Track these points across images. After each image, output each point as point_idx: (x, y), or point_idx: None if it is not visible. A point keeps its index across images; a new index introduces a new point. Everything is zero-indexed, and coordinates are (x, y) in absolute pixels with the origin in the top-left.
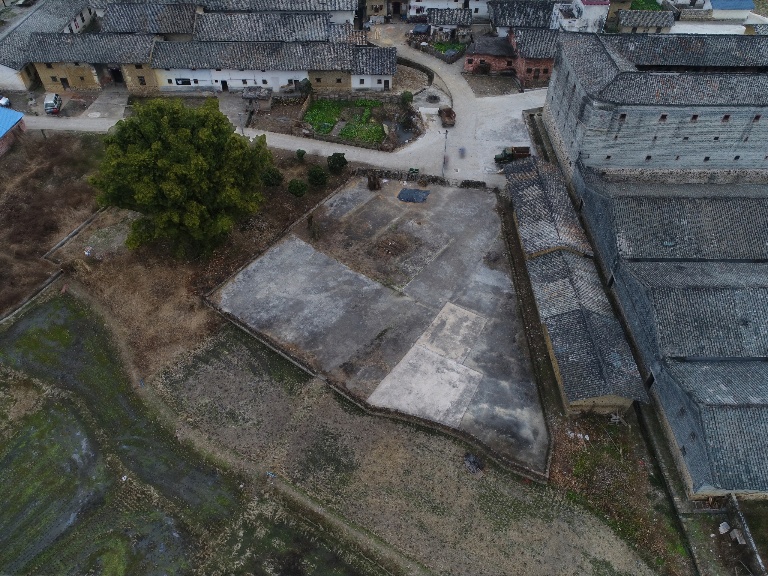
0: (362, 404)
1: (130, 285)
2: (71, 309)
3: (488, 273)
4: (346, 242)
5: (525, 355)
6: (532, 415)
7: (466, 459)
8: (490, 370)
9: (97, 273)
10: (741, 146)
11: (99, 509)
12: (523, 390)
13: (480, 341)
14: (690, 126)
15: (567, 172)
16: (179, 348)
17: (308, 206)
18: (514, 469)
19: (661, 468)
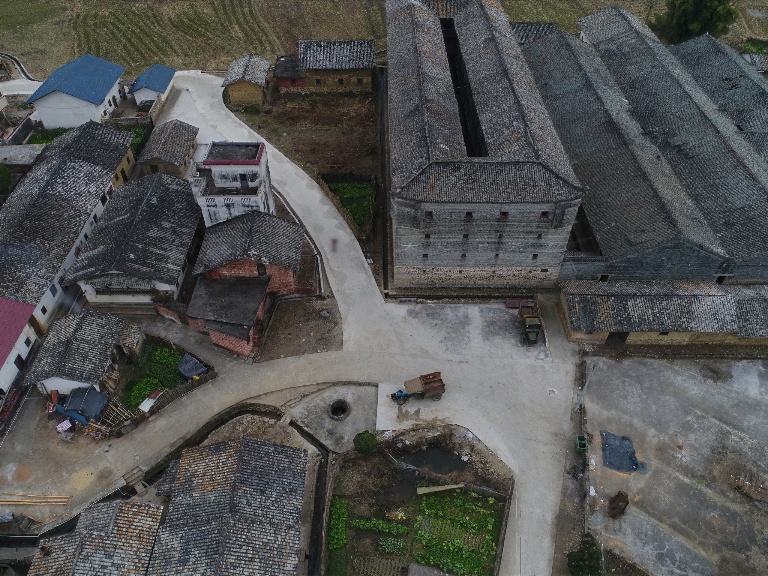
0: None
1: None
2: None
3: (741, 381)
4: (766, 548)
5: None
6: None
7: None
8: None
9: None
10: None
11: None
12: None
13: None
14: None
15: (540, 280)
16: None
17: None
18: None
19: None
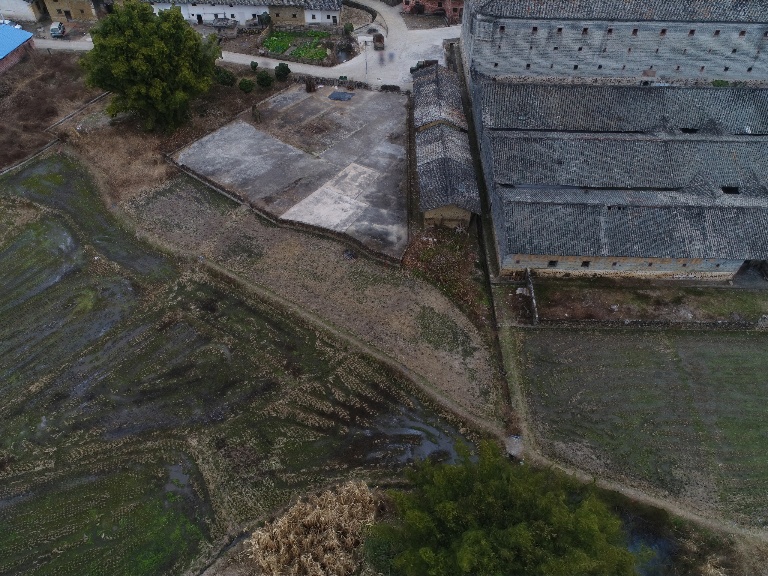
0: (274, 218)
1: (110, 147)
2: (64, 163)
3: (388, 146)
4: (281, 125)
5: (404, 195)
6: (399, 229)
7: (345, 253)
8: (375, 203)
9: (85, 139)
10: (602, 56)
11: (77, 274)
12: (397, 215)
13: (372, 186)
14: (557, 37)
15: (467, 80)
16: (143, 186)
17: (255, 101)
18: (377, 256)
19: (486, 260)
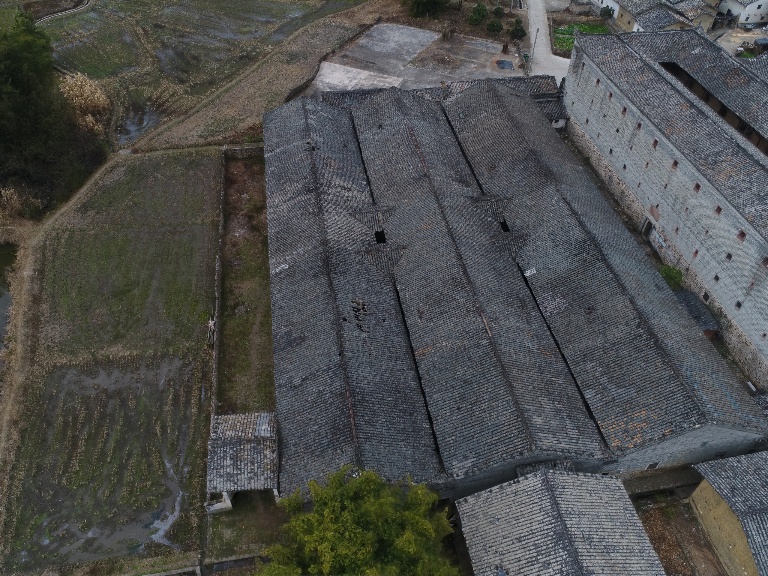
0: None
1: (383, 4)
2: None
3: None
4: (443, 48)
5: None
6: None
7: None
8: None
9: None
10: None
11: None
12: None
13: None
14: (608, 103)
15: None
16: (349, 21)
17: (471, 35)
18: None
19: None
